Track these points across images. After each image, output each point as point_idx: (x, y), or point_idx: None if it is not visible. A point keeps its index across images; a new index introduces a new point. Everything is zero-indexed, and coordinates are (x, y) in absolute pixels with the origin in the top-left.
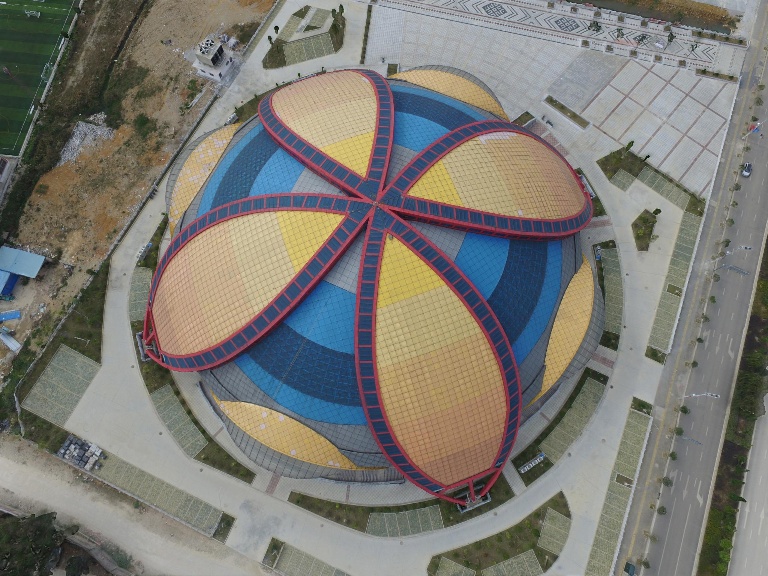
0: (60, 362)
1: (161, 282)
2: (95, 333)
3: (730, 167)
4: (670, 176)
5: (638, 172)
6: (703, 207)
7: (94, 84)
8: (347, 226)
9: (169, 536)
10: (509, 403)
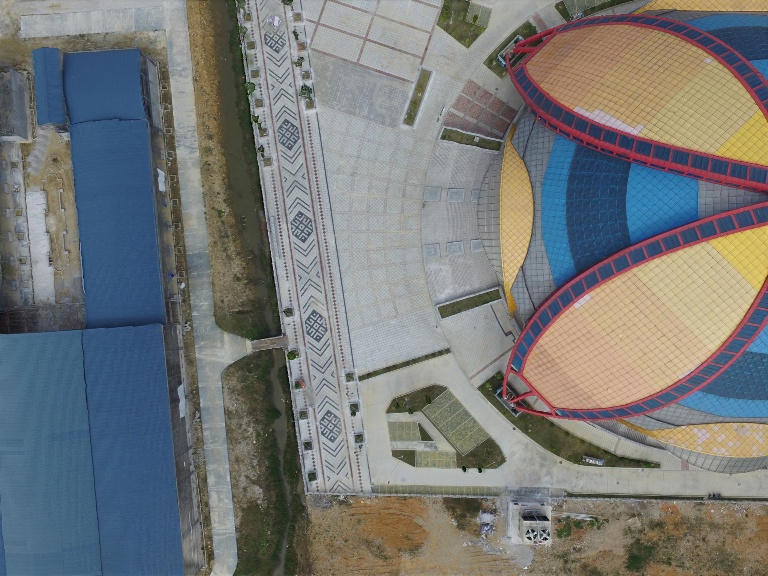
0: None
1: None
2: None
3: None
4: None
5: (462, 2)
6: None
7: None
8: None
9: None
10: None
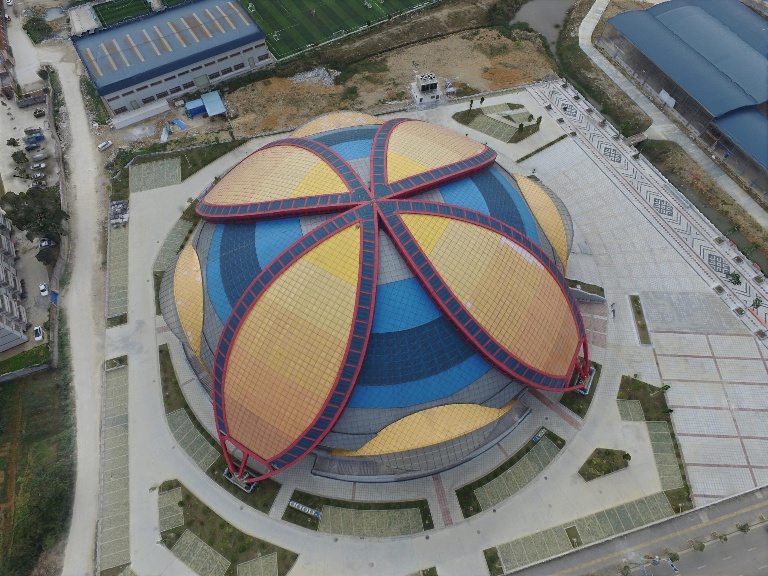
0: (169, 164)
1: None
2: (198, 165)
3: (761, 509)
4: (682, 452)
5: (653, 419)
6: (687, 508)
7: (353, 56)
8: (343, 197)
9: (94, 294)
10: (317, 420)
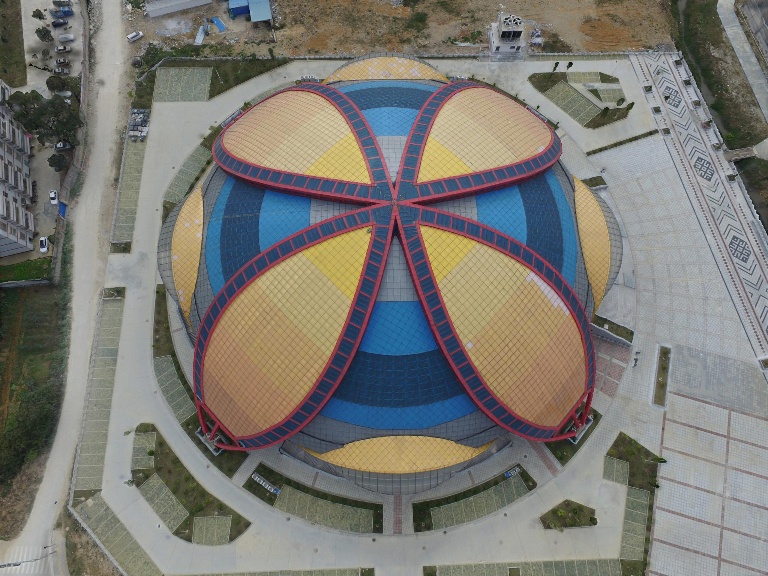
0: (199, 74)
1: (275, 96)
2: (229, 83)
3: None
4: (655, 526)
5: (637, 485)
6: None
7: None
8: (362, 190)
9: (102, 212)
10: (286, 420)
